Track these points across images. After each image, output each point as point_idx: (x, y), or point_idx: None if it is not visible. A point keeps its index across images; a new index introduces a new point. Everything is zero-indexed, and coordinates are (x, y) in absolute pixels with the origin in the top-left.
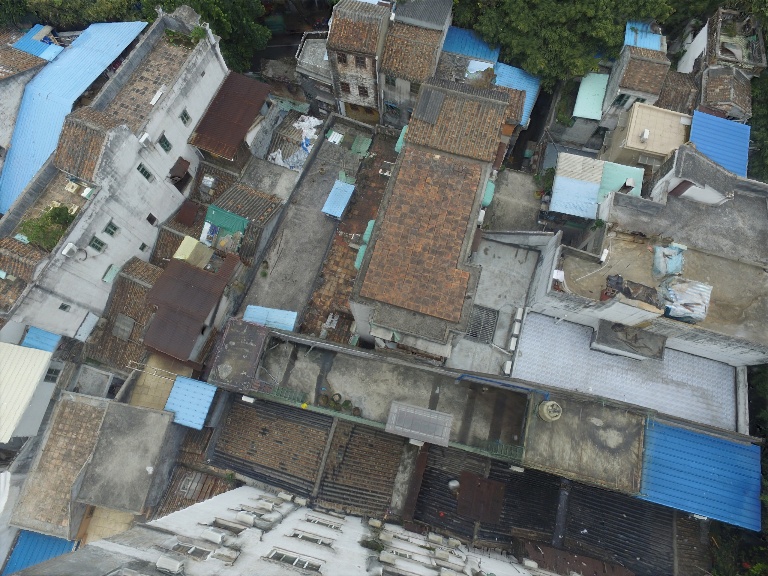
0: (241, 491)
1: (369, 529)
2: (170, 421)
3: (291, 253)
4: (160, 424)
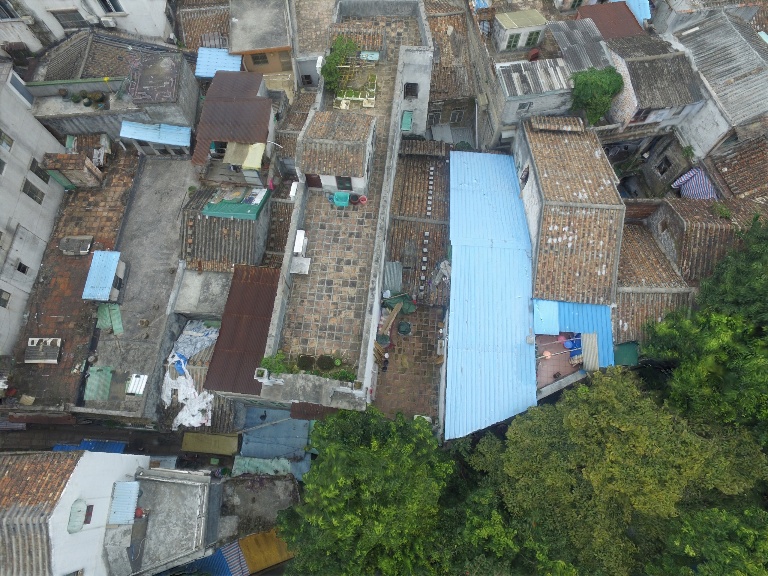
0: (138, 8)
1: (24, 7)
2: (230, 48)
3: (166, 217)
4: (239, 45)
